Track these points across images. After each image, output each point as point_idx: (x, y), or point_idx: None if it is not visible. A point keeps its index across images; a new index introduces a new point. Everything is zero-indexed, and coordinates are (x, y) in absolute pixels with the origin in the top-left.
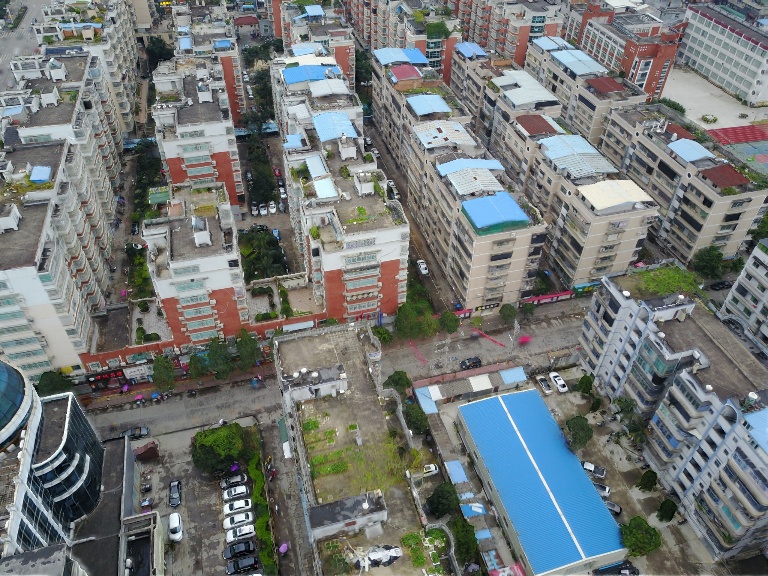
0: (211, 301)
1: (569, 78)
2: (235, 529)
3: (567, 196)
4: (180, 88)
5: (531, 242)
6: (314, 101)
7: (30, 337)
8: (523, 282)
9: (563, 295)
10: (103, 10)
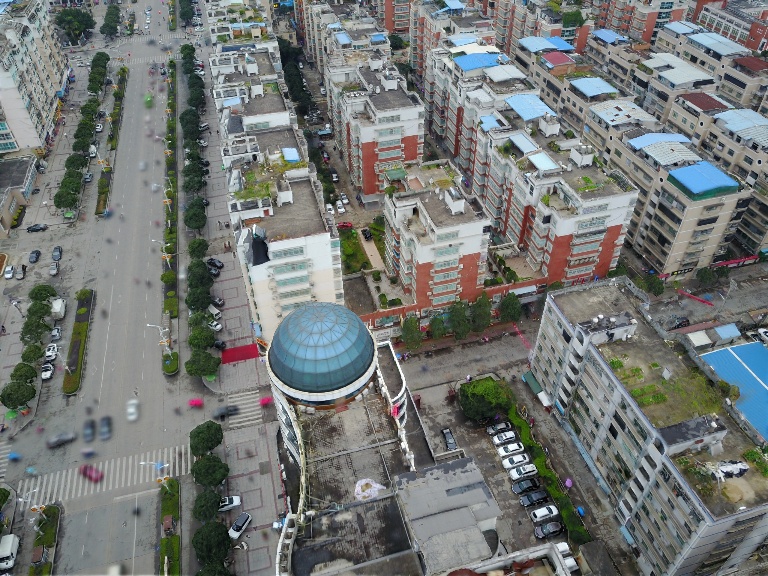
0: (459, 266)
1: (712, 59)
2: (518, 468)
3: (756, 165)
4: (353, 79)
5: (736, 207)
6: (491, 86)
7: (307, 300)
8: (718, 247)
9: (749, 260)
10: (256, 11)
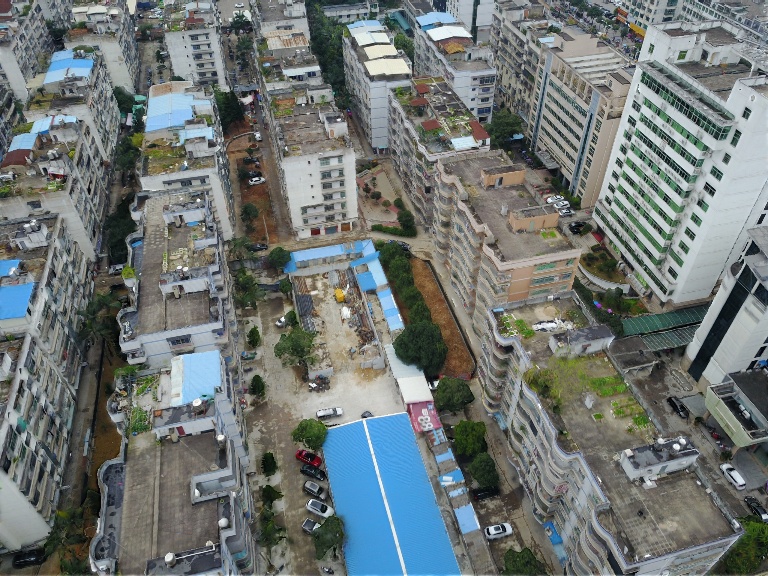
0: None
1: None
2: None
3: None
4: None
5: None
6: None
7: None
8: None
9: None
10: None
